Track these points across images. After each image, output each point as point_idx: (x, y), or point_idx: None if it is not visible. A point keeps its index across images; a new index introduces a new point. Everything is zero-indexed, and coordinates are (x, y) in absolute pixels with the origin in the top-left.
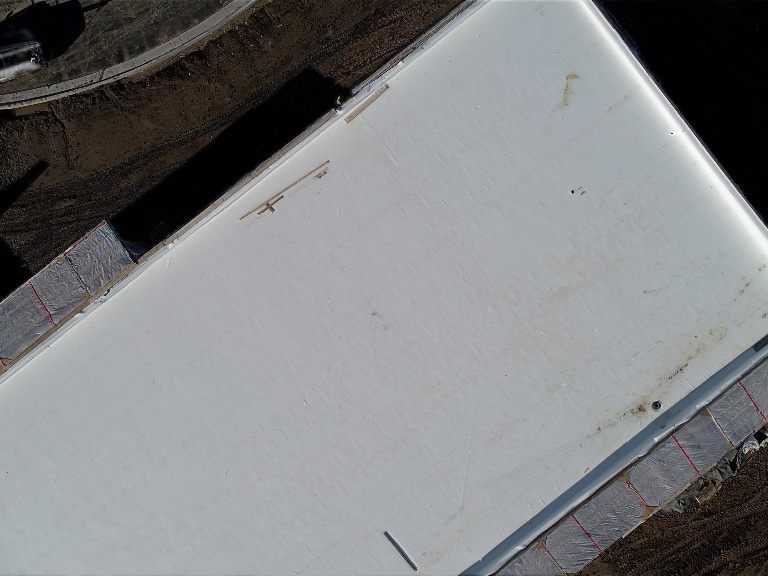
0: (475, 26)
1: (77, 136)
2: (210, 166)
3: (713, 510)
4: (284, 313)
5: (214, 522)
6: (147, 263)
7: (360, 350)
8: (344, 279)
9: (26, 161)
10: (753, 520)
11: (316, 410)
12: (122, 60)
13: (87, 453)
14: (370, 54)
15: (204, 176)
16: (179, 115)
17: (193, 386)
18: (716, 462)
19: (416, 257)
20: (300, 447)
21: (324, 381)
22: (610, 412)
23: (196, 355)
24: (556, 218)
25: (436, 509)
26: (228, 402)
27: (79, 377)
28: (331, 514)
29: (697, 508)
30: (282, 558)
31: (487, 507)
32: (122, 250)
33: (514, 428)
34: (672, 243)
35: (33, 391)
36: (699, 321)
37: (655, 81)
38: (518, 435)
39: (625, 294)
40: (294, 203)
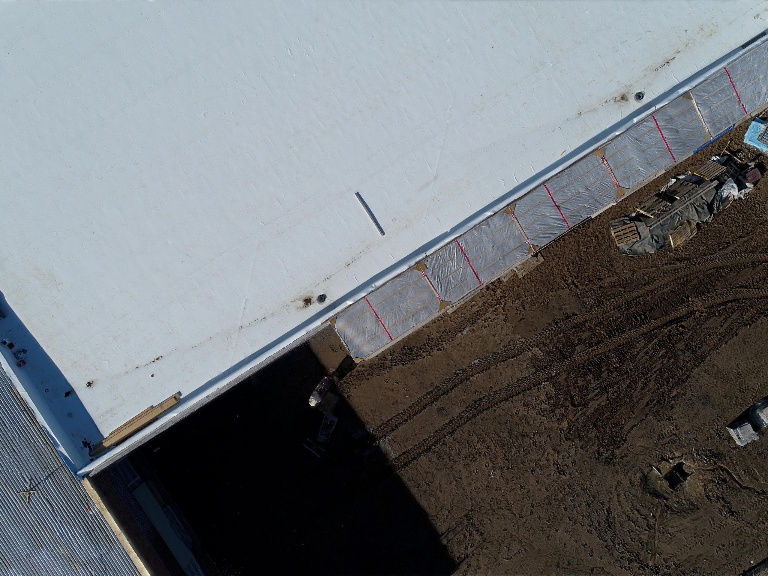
0: None
1: None
2: None
3: (685, 256)
4: None
5: (188, 162)
6: None
7: (350, 5)
8: None
9: None
10: (724, 271)
11: (300, 61)
12: None
13: (68, 78)
14: None
15: None
16: None
17: (180, 22)
18: (693, 152)
19: None
20: (280, 96)
21: (311, 32)
22: (592, 97)
23: None
24: None
25: (409, 175)
26: (213, 42)
27: None
28: (305, 168)
29: (670, 252)
30: (252, 207)
31: (460, 179)
32: None
33: (495, 102)
34: None
35: (21, 8)
36: (691, 15)
37: None
38: (498, 110)
39: None
40: None
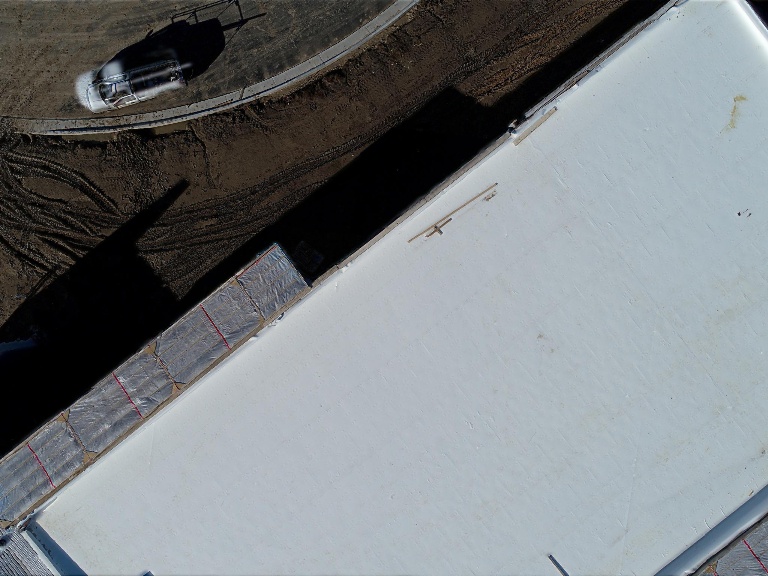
0: (644, 48)
1: (218, 155)
2: (351, 185)
3: None
4: (451, 336)
5: (379, 546)
6: (321, 287)
7: (526, 373)
8: (511, 302)
9: (167, 180)
10: None
11: (482, 433)
12: (262, 79)
13: (254, 476)
14: (511, 73)
15: (345, 195)
16: (320, 134)
17: (360, 409)
18: None
19: (583, 280)
20: (466, 470)
21: (490, 404)
22: None
23: (363, 378)
24: (722, 240)
25: (601, 532)
26: (394, 425)
27: (246, 400)
28: (496, 537)
29: None
30: None
31: (652, 530)
32: (296, 274)
33: (679, 451)
34: None
35: (201, 414)
36: None
37: None
38: (683, 458)
39: None
40: (462, 226)
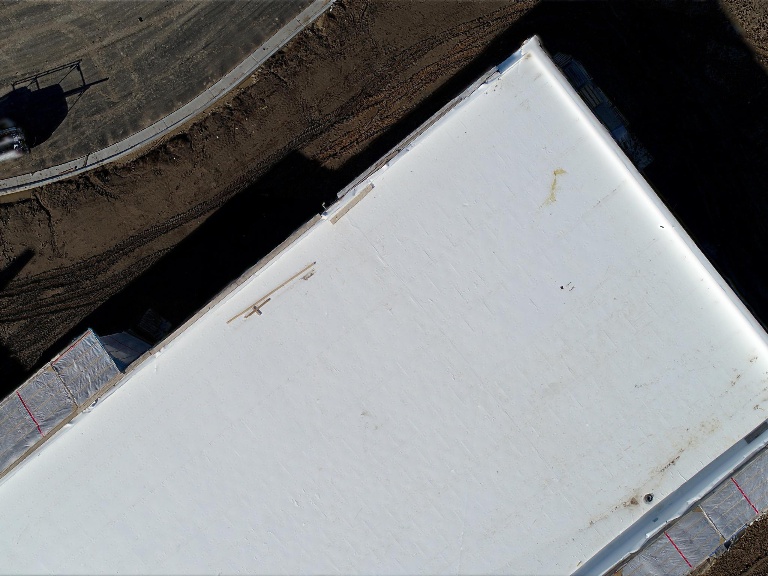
0: (461, 123)
1: (63, 224)
2: (197, 252)
3: None
4: (273, 415)
5: None
6: (134, 372)
7: (351, 450)
8: (333, 380)
9: (12, 250)
10: None
11: (308, 510)
12: (106, 145)
13: (80, 558)
14: (357, 135)
15: (192, 262)
16: (165, 201)
17: (184, 489)
18: (708, 555)
19: (405, 356)
20: (292, 547)
21: (315, 482)
22: (602, 505)
23: (186, 459)
24: (546, 314)
25: None
26: (219, 504)
27: (70, 483)
28: None
29: None
30: None
31: None
32: (109, 360)
33: (506, 524)
34: (663, 336)
35: (24, 498)
36: (691, 413)
37: (644, 176)
38: (510, 530)
39: (616, 388)
40: (281, 305)
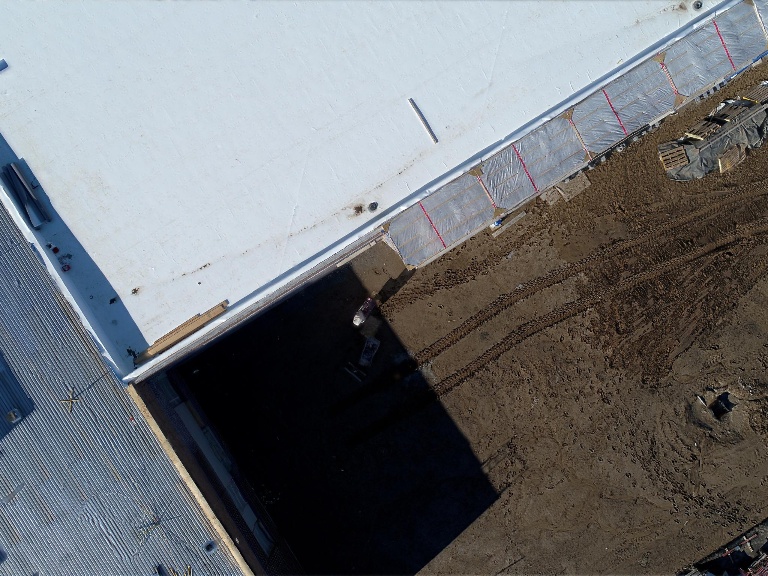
0: None
1: None
2: None
3: (733, 182)
4: None
5: (239, 65)
6: None
7: None
8: None
9: None
10: None
11: None
12: None
13: None
14: None
15: None
16: None
17: None
18: (752, 60)
19: None
20: None
21: None
22: (650, 5)
23: None
24: None
25: (464, 82)
26: None
27: None
28: (358, 73)
29: (718, 178)
30: (303, 112)
31: (515, 86)
32: None
33: (552, 8)
34: None
35: None
36: None
37: None
38: (555, 16)
39: None
40: None
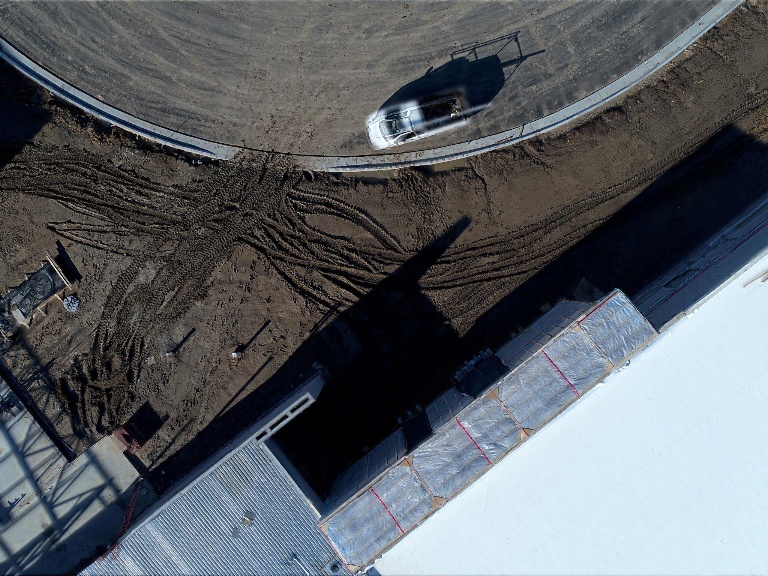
0: None
1: (499, 192)
2: (633, 223)
3: None
4: None
5: None
6: (667, 333)
7: None
8: None
9: (449, 217)
10: None
11: None
12: (541, 116)
13: (586, 520)
14: None
15: (627, 233)
16: (601, 171)
17: (692, 454)
18: None
19: None
20: None
21: None
22: None
23: (696, 423)
24: None
25: None
26: (725, 470)
27: (580, 445)
28: None
29: None
30: None
31: None
32: (642, 320)
33: None
34: None
35: (535, 459)
36: None
37: None
38: None
39: None
40: None
